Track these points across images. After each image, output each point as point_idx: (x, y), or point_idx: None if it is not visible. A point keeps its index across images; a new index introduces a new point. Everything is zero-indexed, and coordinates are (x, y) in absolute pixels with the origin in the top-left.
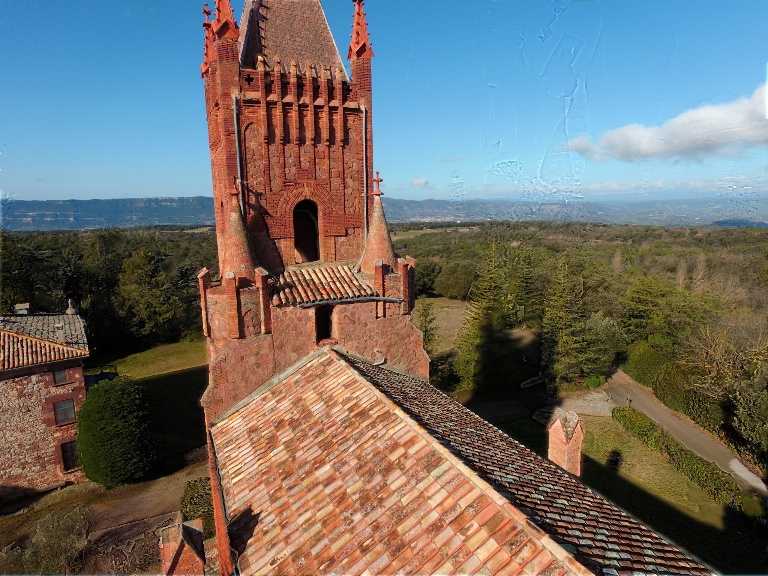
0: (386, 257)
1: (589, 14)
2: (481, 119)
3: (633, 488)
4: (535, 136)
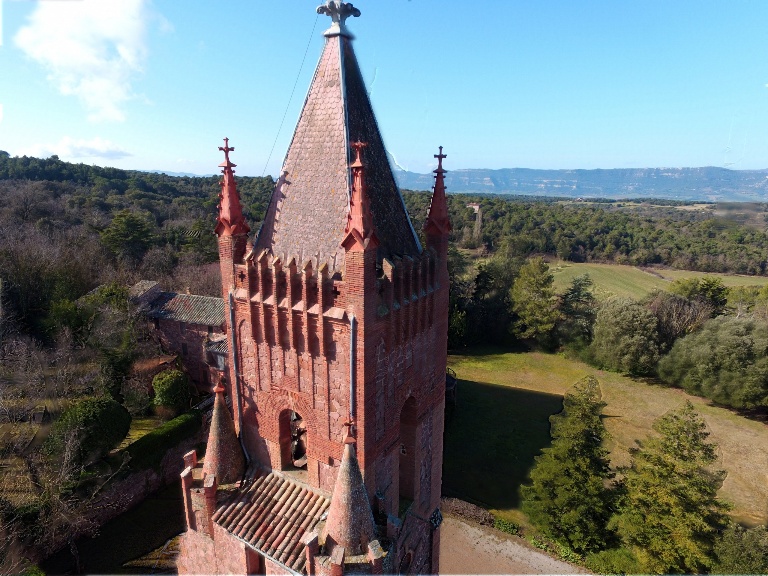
0: (336, 530)
1: None
2: None
3: None
4: None
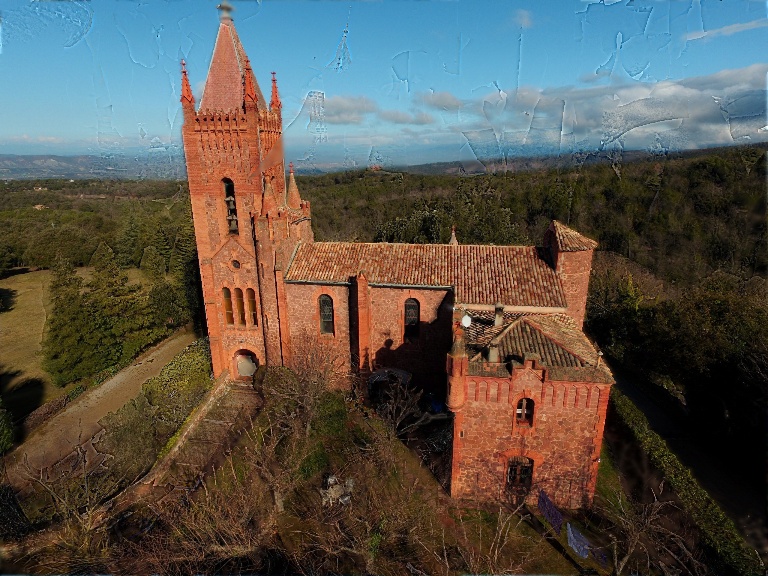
0: None
1: (210, 24)
2: (66, 75)
3: None
4: (129, 99)
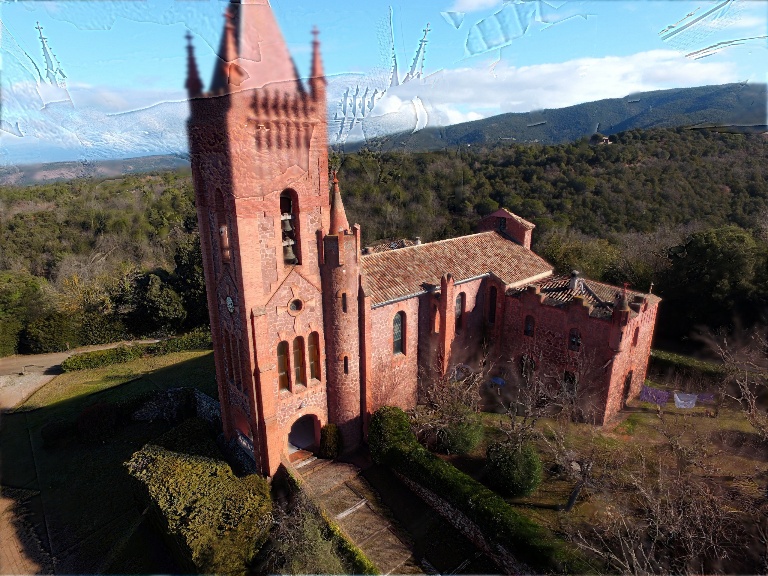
0: None
1: None
2: None
3: (192, 362)
4: None
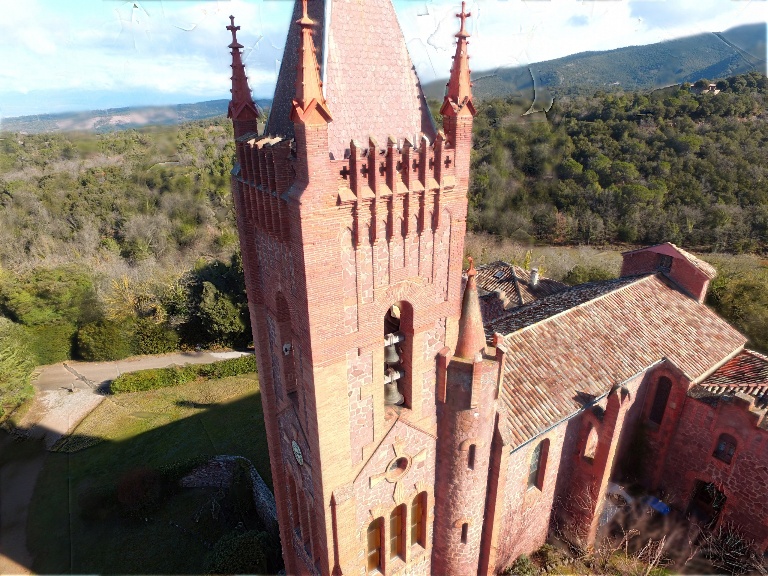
0: None
1: None
2: None
3: (249, 399)
4: None
